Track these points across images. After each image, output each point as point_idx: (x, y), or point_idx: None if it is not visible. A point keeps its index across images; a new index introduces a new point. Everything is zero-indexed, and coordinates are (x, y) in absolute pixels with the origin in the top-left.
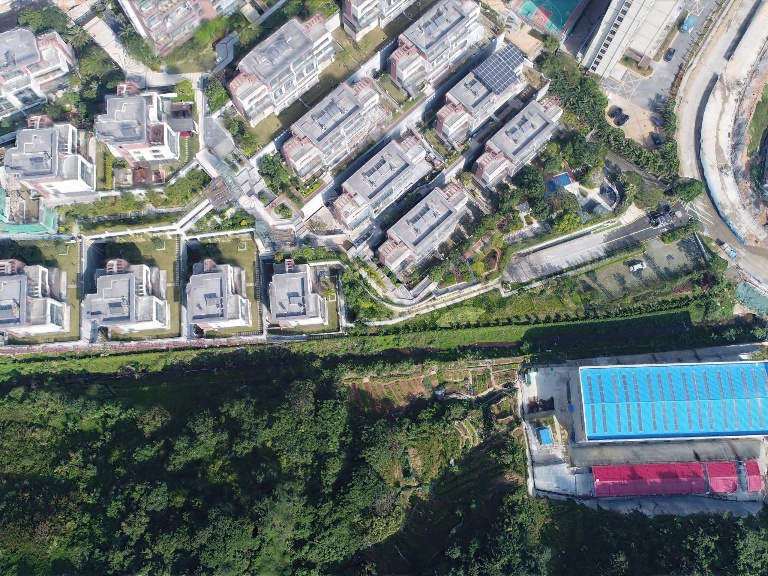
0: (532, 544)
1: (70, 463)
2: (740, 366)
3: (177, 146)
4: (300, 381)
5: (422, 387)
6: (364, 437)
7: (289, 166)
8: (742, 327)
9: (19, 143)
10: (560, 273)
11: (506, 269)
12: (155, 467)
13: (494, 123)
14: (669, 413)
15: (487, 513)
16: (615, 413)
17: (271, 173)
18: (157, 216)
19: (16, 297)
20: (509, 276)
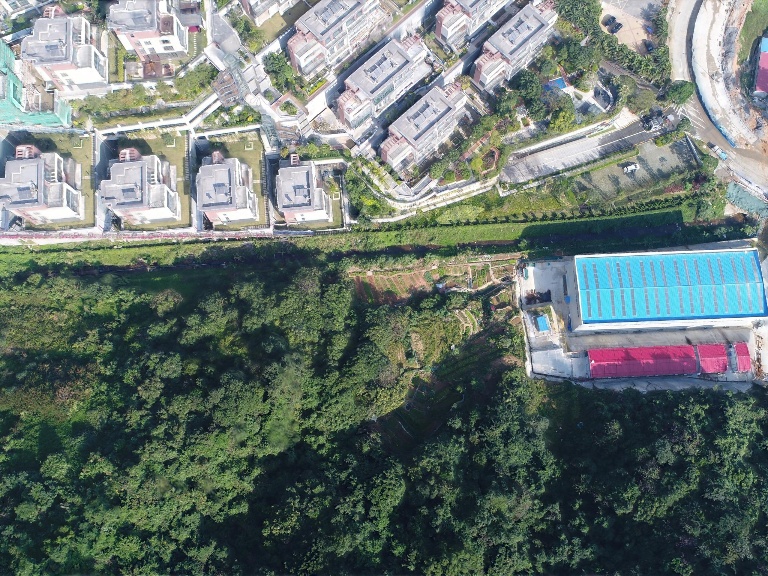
0: (530, 414)
1: (87, 340)
2: (730, 254)
3: (186, 40)
4: (306, 268)
5: (423, 280)
6: (368, 318)
7: (293, 65)
8: (733, 226)
9: (35, 32)
10: (556, 174)
11: (504, 170)
12: (168, 343)
13: (491, 27)
14: (661, 298)
15: (487, 391)
16: (609, 298)
17: (276, 70)
18: (167, 110)
19: (34, 180)
20: (507, 177)
